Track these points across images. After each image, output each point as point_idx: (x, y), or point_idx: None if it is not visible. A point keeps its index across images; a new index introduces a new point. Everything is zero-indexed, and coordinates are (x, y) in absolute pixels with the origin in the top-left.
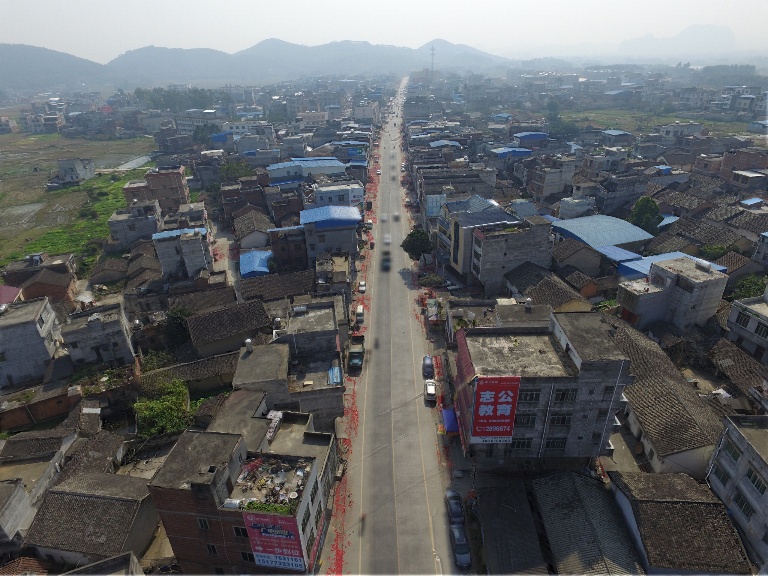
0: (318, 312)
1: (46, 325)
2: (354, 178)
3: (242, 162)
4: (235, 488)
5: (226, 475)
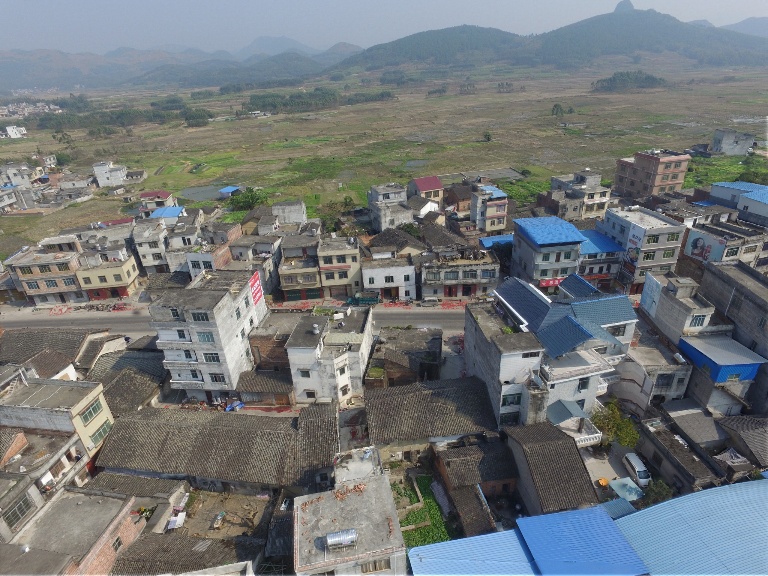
0: (350, 248)
1: (390, 200)
2: (760, 234)
3: None
4: None
5: (211, 235)
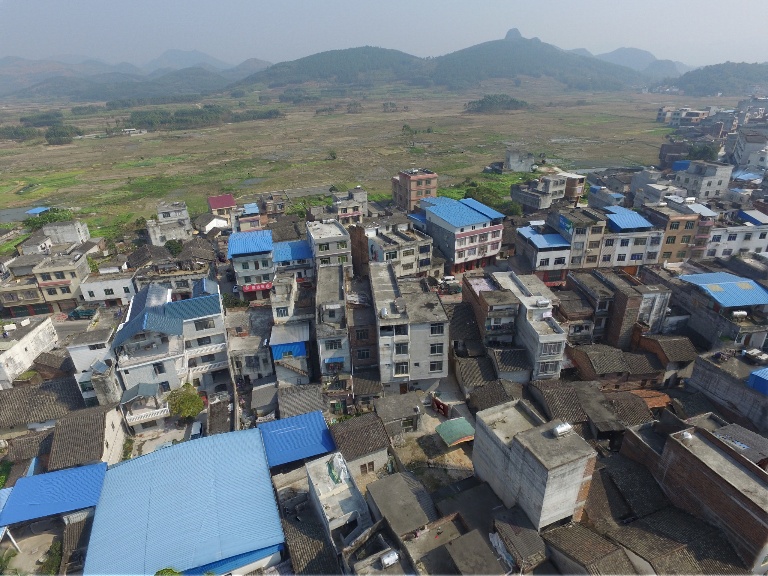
0: (71, 264)
1: (171, 218)
2: (414, 240)
3: (488, 189)
4: None
5: None
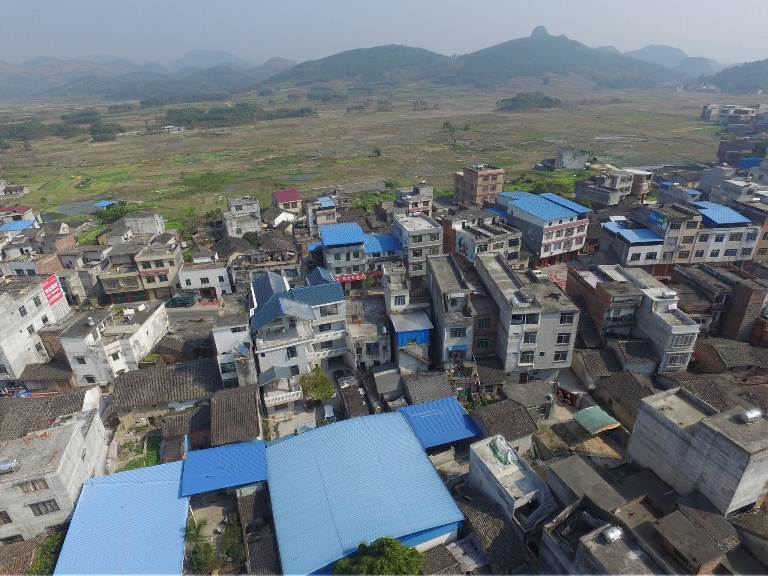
0: (169, 253)
1: (243, 211)
2: (504, 233)
3: None
4: (44, 254)
5: (40, 245)
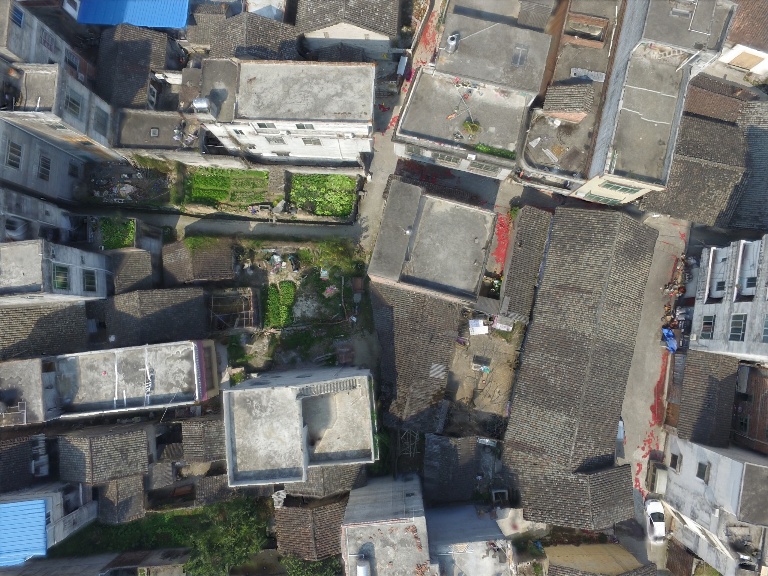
0: None
1: None
2: None
3: None
4: None
5: None
